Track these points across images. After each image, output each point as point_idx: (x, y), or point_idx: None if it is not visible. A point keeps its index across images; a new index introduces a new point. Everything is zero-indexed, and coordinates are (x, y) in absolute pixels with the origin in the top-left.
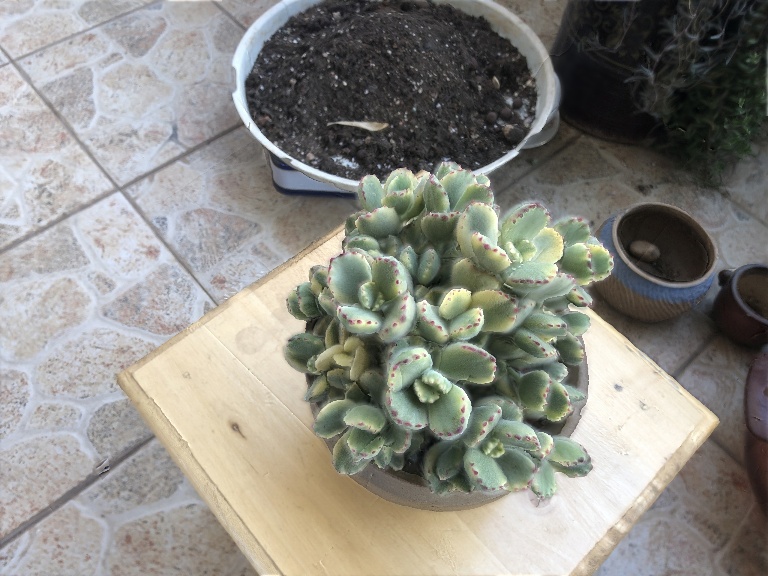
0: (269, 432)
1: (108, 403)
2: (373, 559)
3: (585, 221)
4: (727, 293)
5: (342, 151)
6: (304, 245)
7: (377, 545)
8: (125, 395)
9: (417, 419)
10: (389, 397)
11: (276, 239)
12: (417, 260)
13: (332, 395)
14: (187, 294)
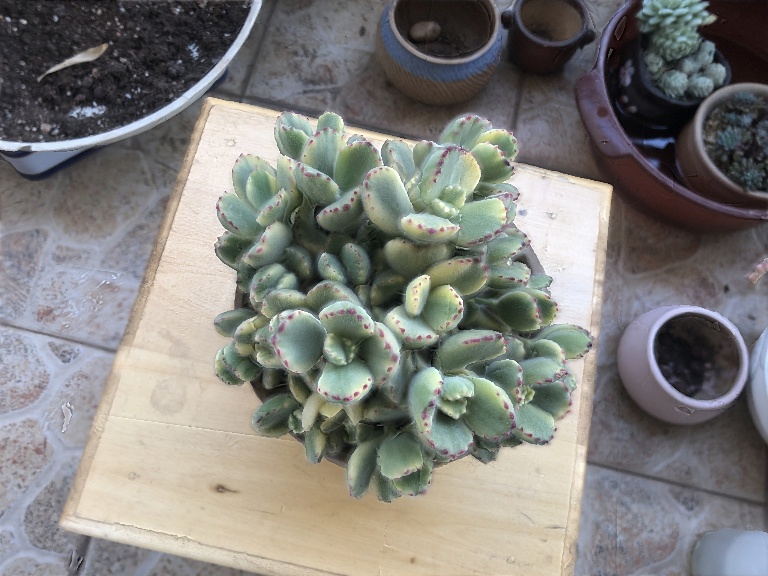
0: (256, 470)
1: (30, 504)
2: (425, 509)
3: (355, 31)
4: (516, 34)
5: (76, 101)
6: (104, 221)
7: (421, 495)
8: (41, 485)
9: (463, 438)
10: (428, 440)
11: (71, 233)
12: (341, 265)
13: (334, 439)
14: (22, 348)
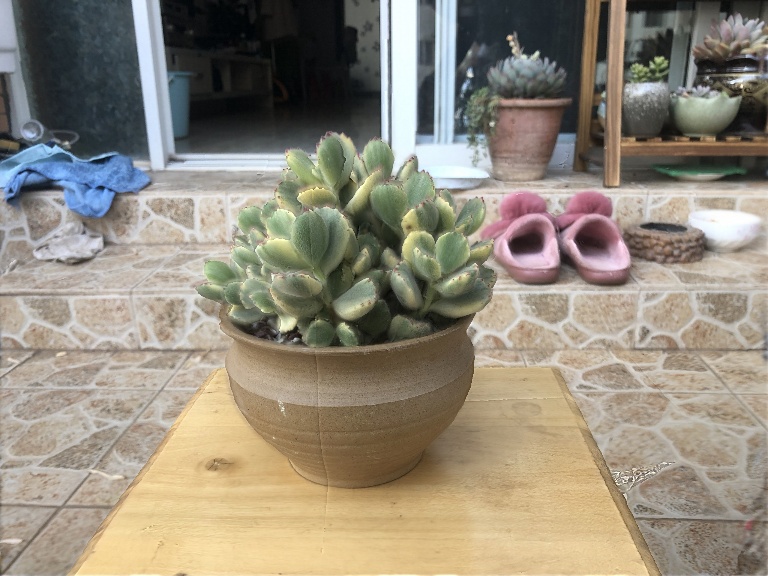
0: None
1: None
2: None
3: None
4: None
5: None
6: None
7: None
8: None
9: None
10: None
11: None
12: None
13: None
14: None
